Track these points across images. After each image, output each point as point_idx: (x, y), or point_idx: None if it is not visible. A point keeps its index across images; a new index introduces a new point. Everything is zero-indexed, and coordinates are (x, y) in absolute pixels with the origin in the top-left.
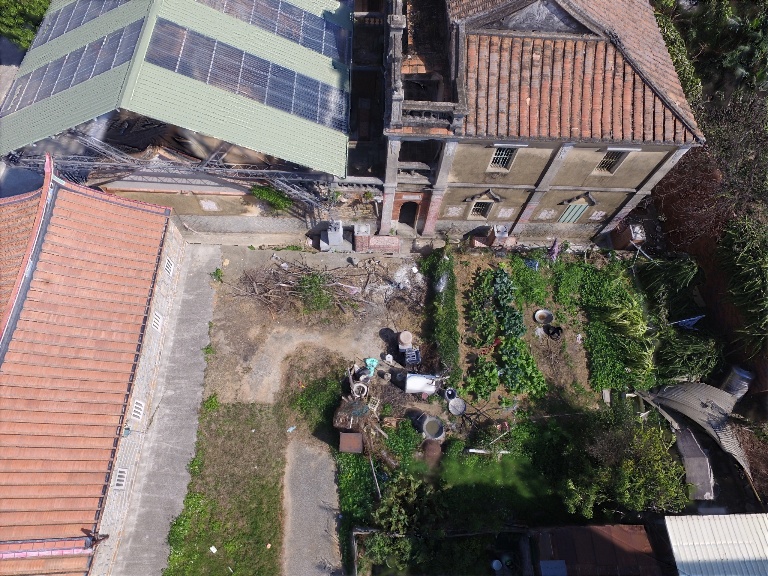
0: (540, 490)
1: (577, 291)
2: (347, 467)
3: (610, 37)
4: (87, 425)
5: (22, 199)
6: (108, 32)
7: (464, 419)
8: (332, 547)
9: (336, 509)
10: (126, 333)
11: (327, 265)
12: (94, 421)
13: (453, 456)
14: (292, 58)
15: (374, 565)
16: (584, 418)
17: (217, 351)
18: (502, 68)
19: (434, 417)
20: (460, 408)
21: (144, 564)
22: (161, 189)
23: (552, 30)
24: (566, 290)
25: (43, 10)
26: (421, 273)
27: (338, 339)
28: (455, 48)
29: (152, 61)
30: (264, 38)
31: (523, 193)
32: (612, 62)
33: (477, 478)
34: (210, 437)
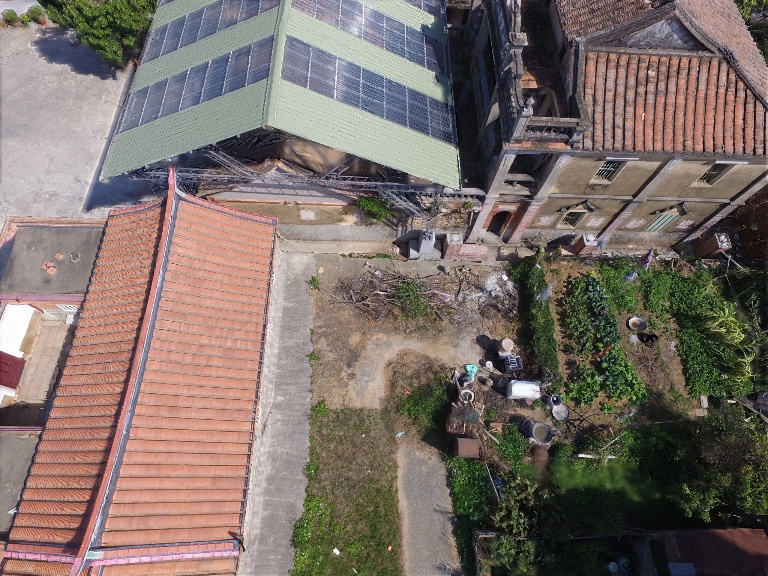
0: (649, 494)
1: (667, 299)
2: (460, 471)
3: (724, 54)
4: (223, 431)
5: (138, 210)
6: (232, 49)
7: (568, 425)
8: (450, 549)
9: (450, 512)
10: (249, 341)
11: (419, 273)
12: (229, 427)
13: (562, 461)
14: (401, 73)
15: (493, 567)
16: (684, 424)
17: (321, 358)
18: (618, 84)
19: (541, 423)
20: (563, 414)
21: (272, 565)
22: (266, 199)
23: (669, 47)
24: (657, 298)
25: (133, 22)
26: (511, 281)
27: (437, 346)
28: (573, 65)
29: (287, 79)
30: (376, 53)
31: (618, 203)
32: (725, 78)
33: (586, 482)
34: (322, 442)
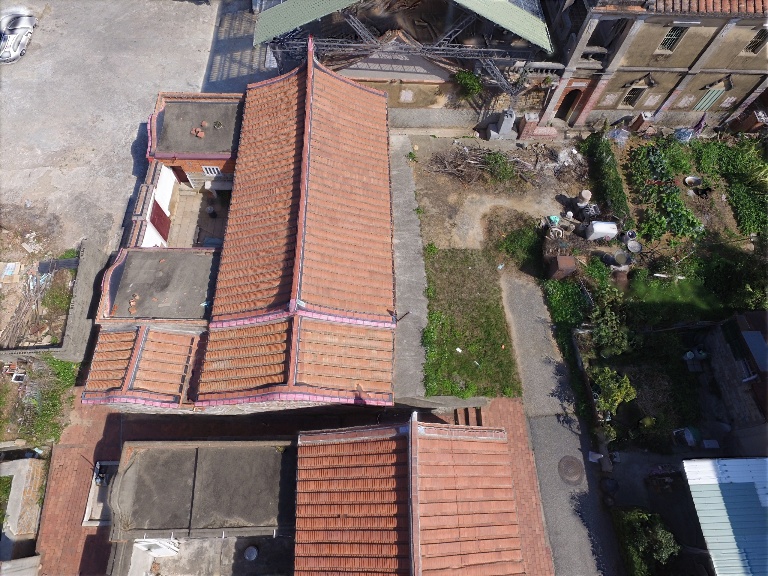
0: (714, 304)
1: (716, 163)
2: (555, 290)
3: None
4: (371, 240)
5: (274, 81)
6: None
7: (642, 256)
8: (552, 348)
9: (550, 322)
10: (380, 180)
11: (500, 149)
12: (375, 238)
13: (640, 280)
14: None
15: (590, 359)
16: (738, 254)
17: (426, 212)
18: None
19: None
20: (637, 248)
21: (407, 360)
22: (376, 78)
23: None
24: (707, 162)
25: None
26: (581, 153)
27: (523, 203)
28: None
29: None
30: None
31: (675, 77)
32: None
33: (660, 297)
34: (436, 273)
